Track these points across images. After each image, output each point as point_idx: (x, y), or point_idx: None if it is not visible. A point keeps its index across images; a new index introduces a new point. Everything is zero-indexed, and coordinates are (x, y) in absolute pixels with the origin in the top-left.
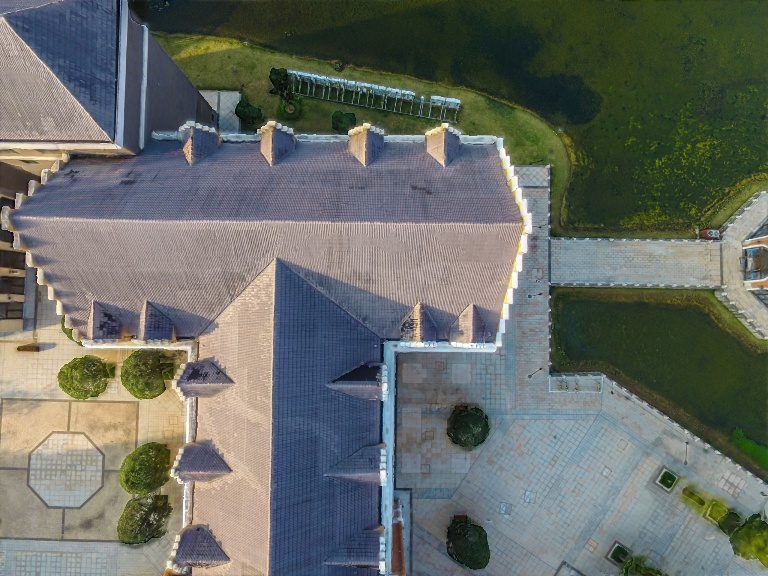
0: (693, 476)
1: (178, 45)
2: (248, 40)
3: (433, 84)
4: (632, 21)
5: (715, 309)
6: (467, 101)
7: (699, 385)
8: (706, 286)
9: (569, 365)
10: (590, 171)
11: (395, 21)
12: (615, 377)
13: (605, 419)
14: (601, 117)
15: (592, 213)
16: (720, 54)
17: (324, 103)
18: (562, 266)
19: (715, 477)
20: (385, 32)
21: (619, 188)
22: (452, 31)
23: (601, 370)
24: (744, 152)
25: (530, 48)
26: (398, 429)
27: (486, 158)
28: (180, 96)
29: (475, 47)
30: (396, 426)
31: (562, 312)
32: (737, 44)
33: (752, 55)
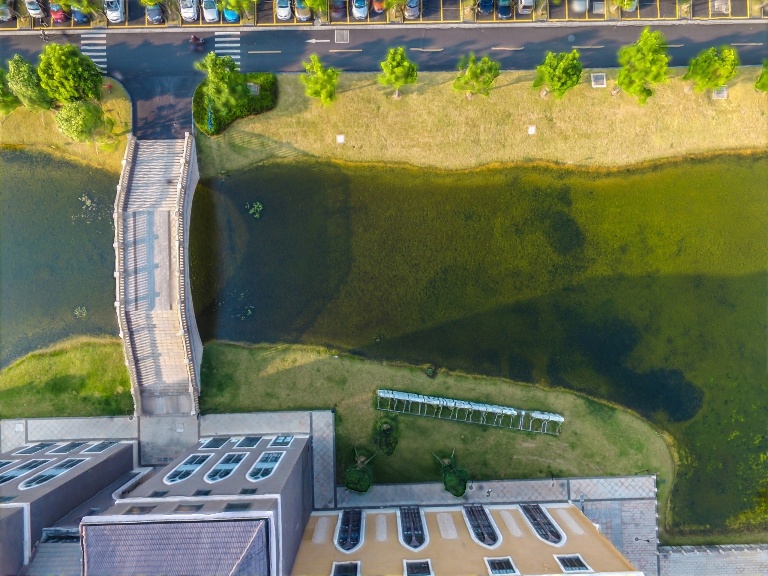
0: None
1: (264, 358)
2: (336, 347)
3: (530, 387)
4: (732, 309)
5: None
6: (567, 406)
7: None
8: None
9: None
10: (694, 469)
11: (487, 319)
12: None
13: None
14: (703, 413)
15: (697, 513)
16: None
17: (420, 419)
18: None
19: None
20: (477, 332)
21: (724, 486)
22: (547, 328)
23: None
24: None
25: (628, 343)
26: None
27: None
28: (294, 493)
29: (571, 344)
30: None
31: None
32: None
33: None
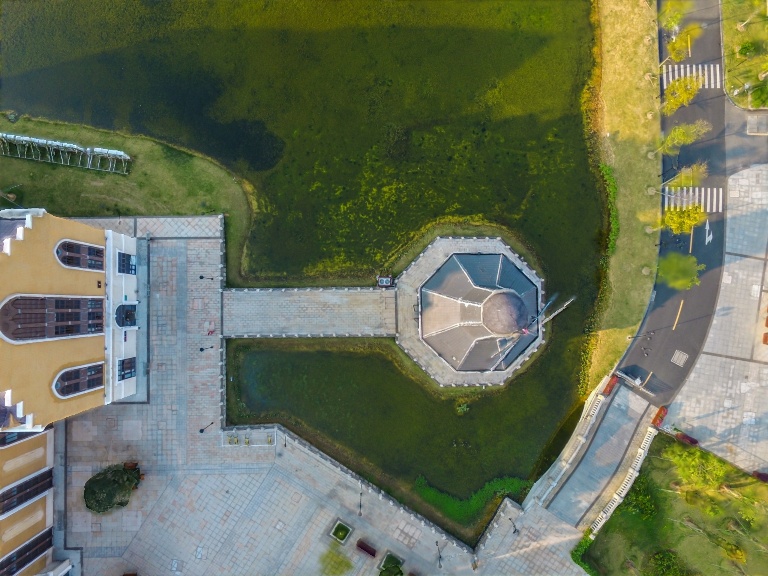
0: (367, 527)
1: None
2: None
3: (110, 133)
4: (316, 63)
5: (397, 356)
6: (142, 150)
7: (383, 433)
8: (381, 335)
9: (248, 417)
10: (273, 218)
11: (73, 69)
12: (295, 428)
13: (278, 472)
14: (284, 163)
15: (275, 261)
16: (406, 95)
17: None
18: (235, 318)
19: (390, 527)
20: (62, 80)
21: (303, 235)
22: (131, 78)
23: (281, 421)
24: (431, 195)
25: (211, 94)
26: (68, 488)
27: (2, 238)
28: None
29: (155, 94)
30: (66, 485)
31: (243, 363)
32: (424, 84)
33: (439, 95)
